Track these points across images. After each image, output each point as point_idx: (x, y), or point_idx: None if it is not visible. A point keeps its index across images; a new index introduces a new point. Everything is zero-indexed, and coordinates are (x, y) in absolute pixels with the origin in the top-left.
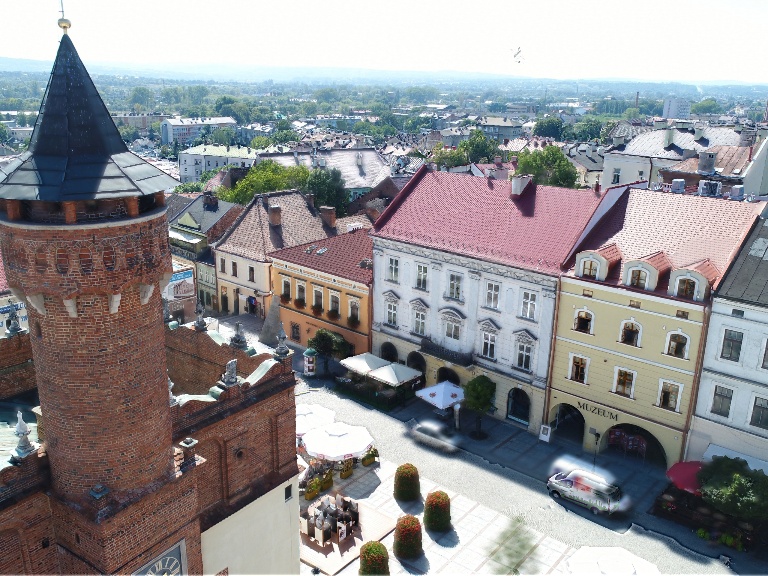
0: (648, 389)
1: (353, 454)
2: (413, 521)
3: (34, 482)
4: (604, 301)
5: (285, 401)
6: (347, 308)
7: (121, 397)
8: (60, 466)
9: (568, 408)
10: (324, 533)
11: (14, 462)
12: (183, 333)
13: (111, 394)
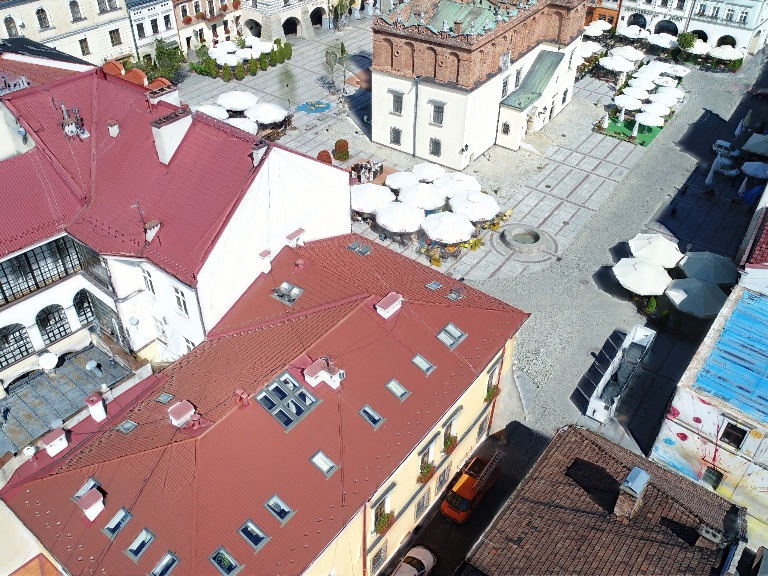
0: None
1: None
2: (322, 151)
3: None
4: None
5: None
6: None
7: None
8: None
9: None
10: None
11: None
12: None
13: None
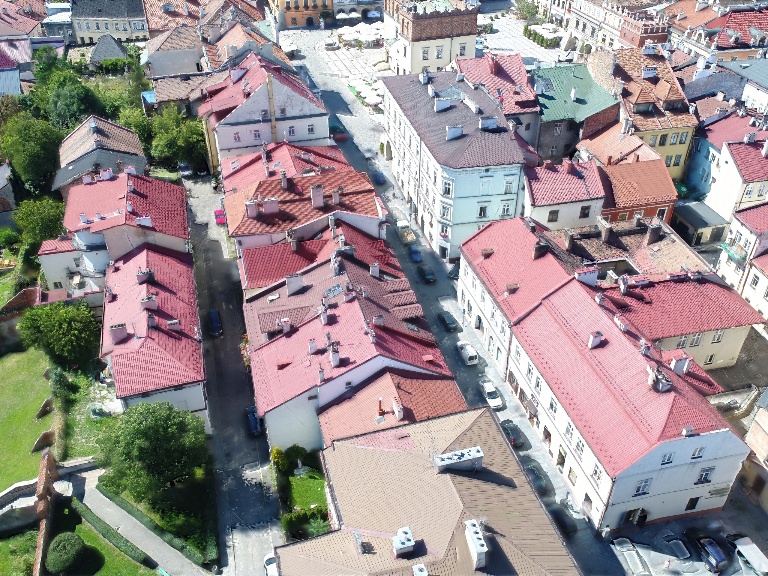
0: None
1: None
2: None
3: None
4: None
5: None
6: None
7: None
8: None
9: None
10: None
11: None
12: None
13: None
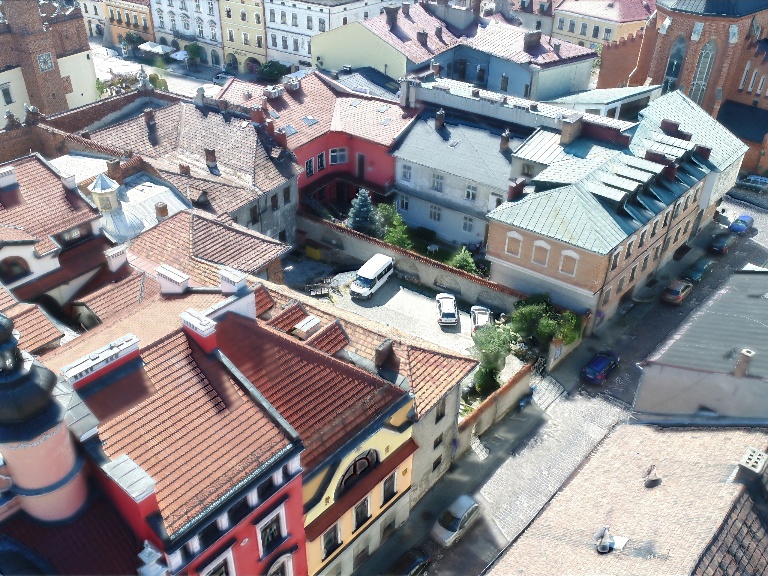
0: (253, 40)
1: (132, 72)
2: None
3: (7, 30)
4: (233, 2)
5: (81, 23)
6: (142, 21)
7: (25, 4)
8: (13, 25)
9: (234, 56)
10: (116, 92)
11: (1, 24)
12: (45, 5)
13: (23, 3)
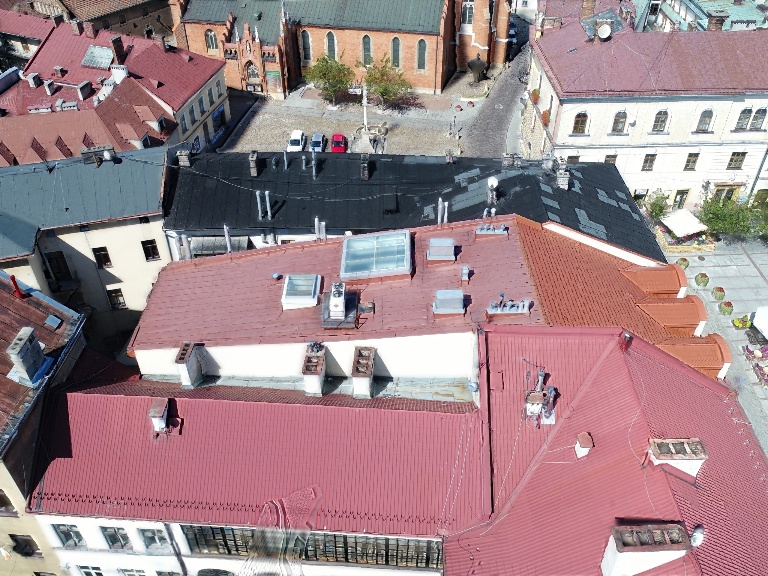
0: None
1: None
2: None
3: None
4: None
5: None
6: None
7: None
8: None
9: None
10: None
11: None
12: None
13: None
